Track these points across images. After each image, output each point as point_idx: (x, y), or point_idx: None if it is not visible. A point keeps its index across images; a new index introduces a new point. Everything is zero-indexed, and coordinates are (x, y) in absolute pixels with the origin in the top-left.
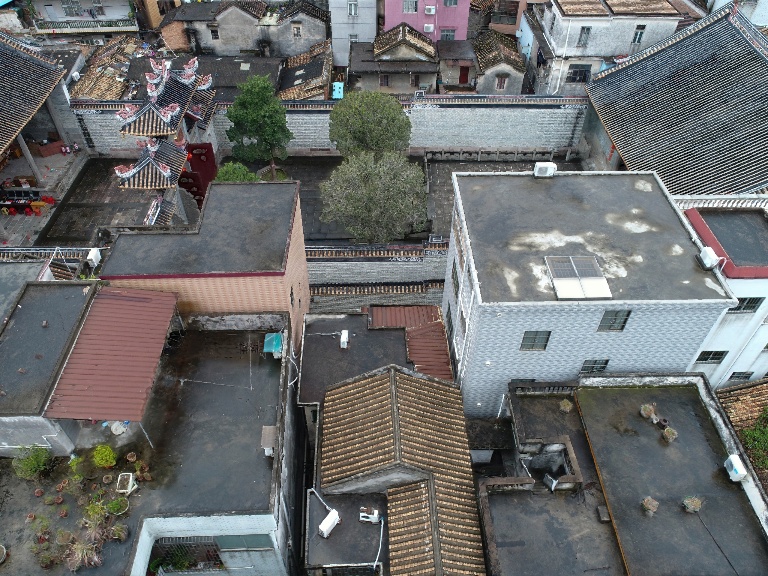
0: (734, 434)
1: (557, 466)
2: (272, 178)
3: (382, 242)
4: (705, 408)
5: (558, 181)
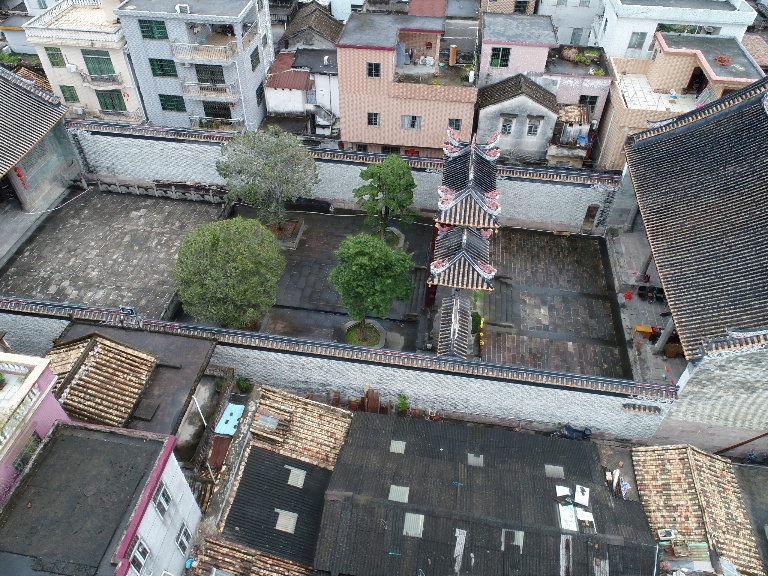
0: None
1: None
2: (365, 335)
3: None
4: None
5: None
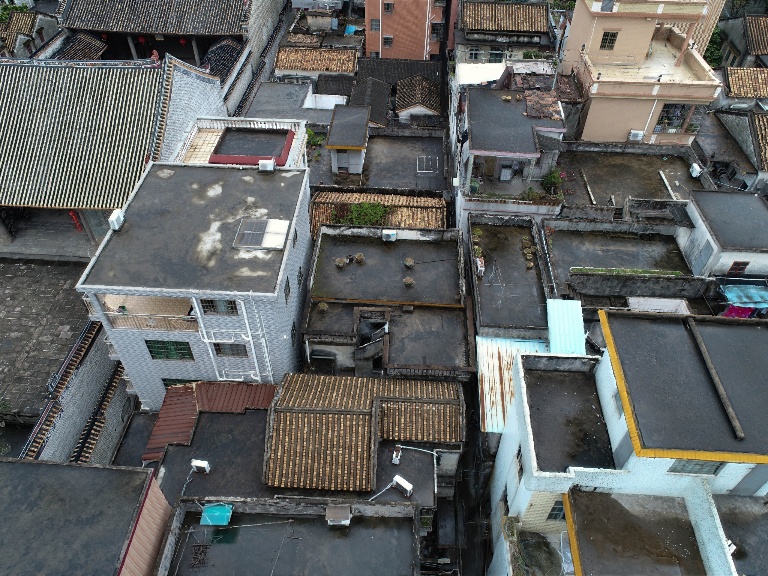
0: (369, 226)
1: (365, 328)
2: None
3: (5, 452)
4: (340, 236)
5: (132, 218)
